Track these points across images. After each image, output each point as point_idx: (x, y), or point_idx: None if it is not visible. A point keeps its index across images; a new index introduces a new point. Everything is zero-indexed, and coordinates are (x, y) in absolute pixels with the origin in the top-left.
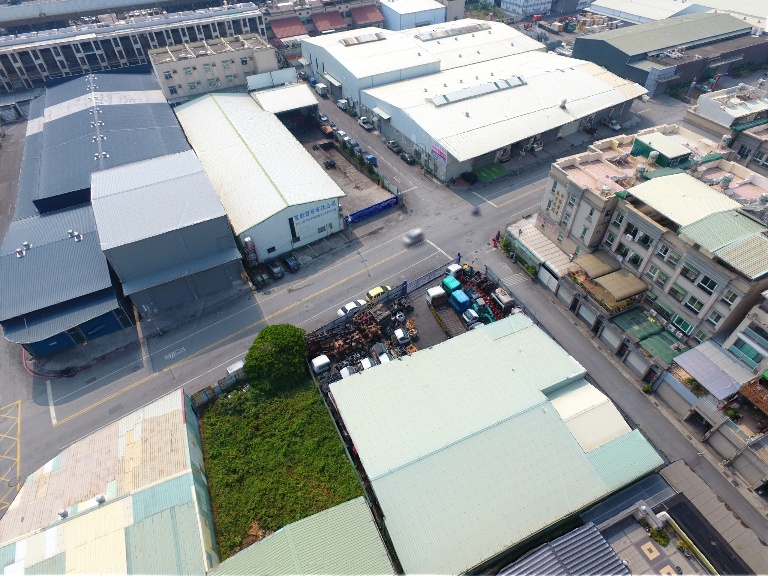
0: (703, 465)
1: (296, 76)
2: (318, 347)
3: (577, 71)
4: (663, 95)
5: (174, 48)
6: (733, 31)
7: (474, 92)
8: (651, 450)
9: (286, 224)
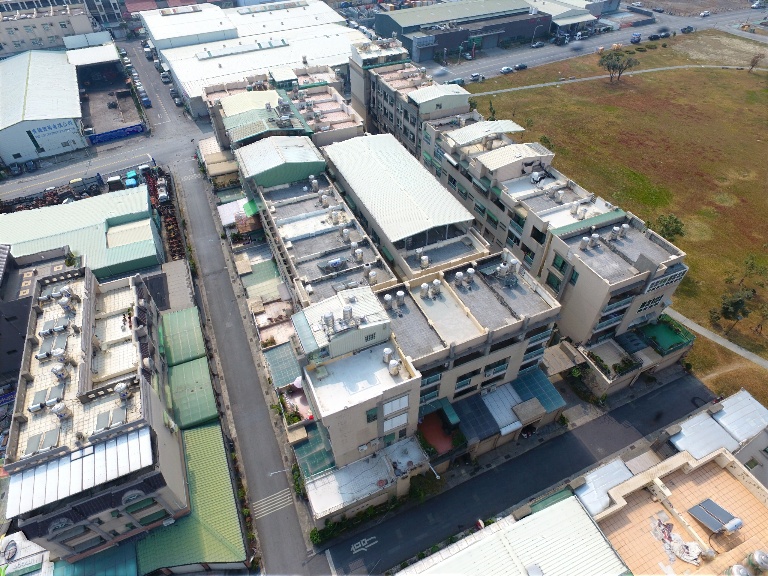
0: (222, 273)
1: (111, 39)
2: (6, 210)
3: (340, 37)
4: (430, 60)
5: (7, 14)
6: (511, 10)
7: (237, 50)
8: (153, 248)
9: (26, 136)
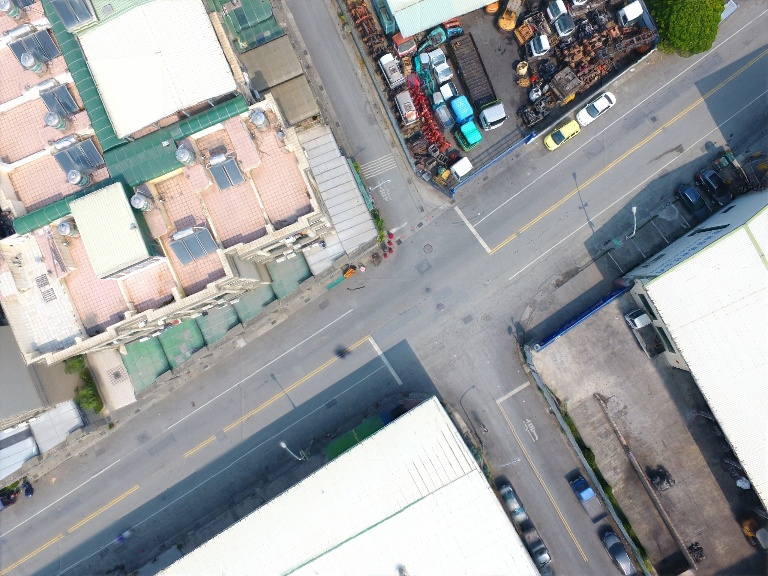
0: None
1: None
2: None
3: None
4: None
5: None
6: None
7: None
8: None
9: None
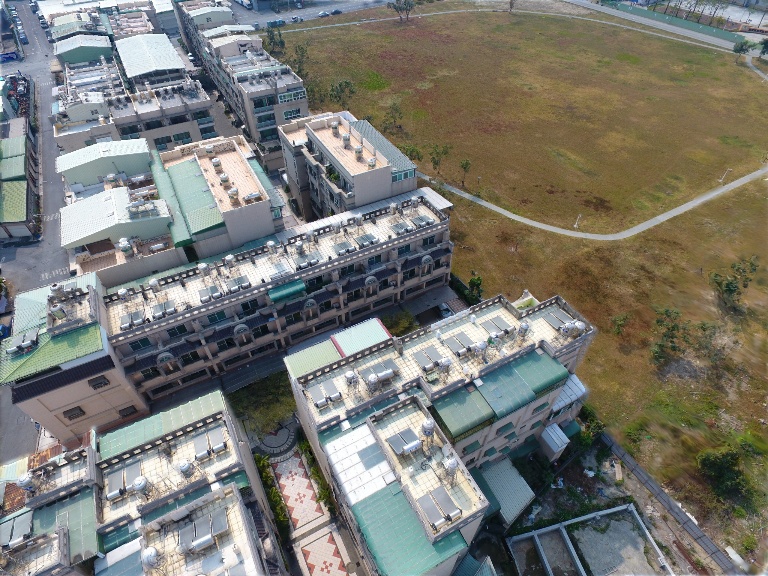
0: None
1: None
2: None
3: None
4: (268, 9)
5: None
6: None
7: None
8: (1, 108)
9: None
